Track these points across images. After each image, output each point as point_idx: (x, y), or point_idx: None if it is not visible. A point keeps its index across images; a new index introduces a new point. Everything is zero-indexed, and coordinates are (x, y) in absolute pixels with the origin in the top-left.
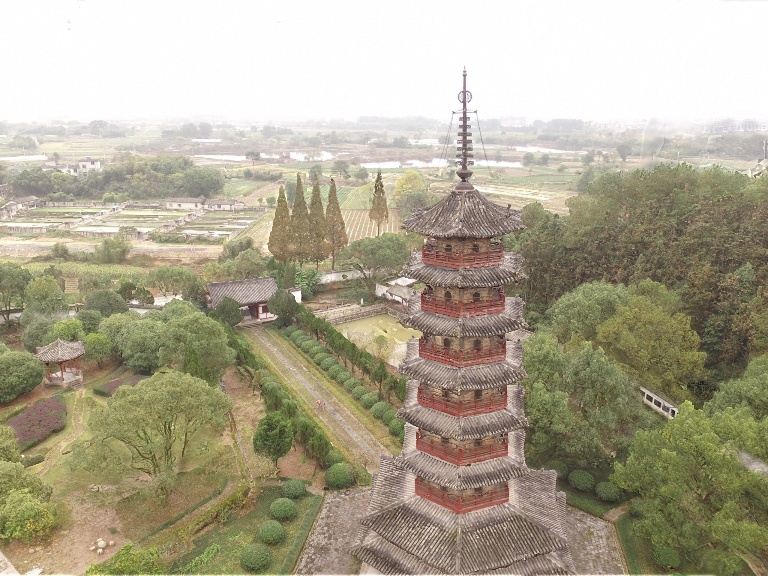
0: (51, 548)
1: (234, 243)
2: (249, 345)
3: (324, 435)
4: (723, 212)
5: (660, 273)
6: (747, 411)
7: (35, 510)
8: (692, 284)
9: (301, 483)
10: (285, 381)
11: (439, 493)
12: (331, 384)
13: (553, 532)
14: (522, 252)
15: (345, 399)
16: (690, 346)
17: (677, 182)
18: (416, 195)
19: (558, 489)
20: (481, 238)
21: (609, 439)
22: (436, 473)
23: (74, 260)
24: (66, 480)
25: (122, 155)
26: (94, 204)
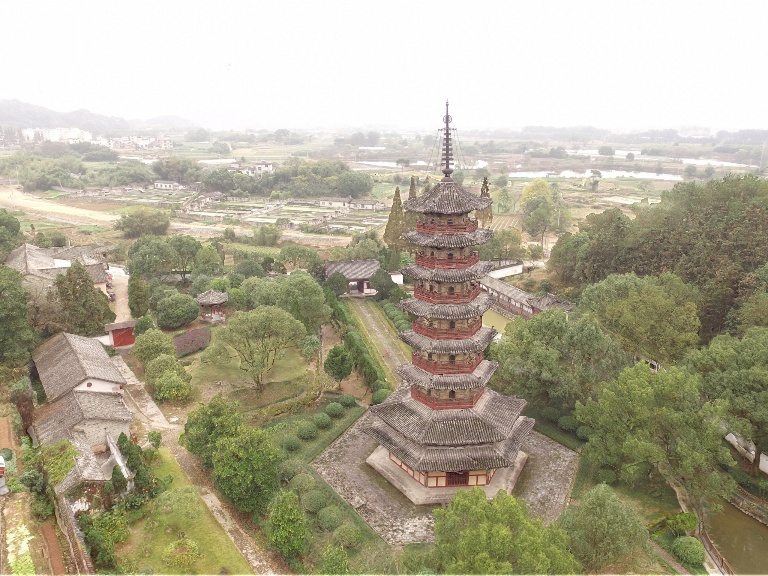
0: (186, 409)
1: (360, 234)
2: (350, 310)
3: (382, 373)
4: (767, 219)
5: (696, 271)
6: (685, 369)
7: (178, 383)
8: (719, 281)
9: (352, 396)
10: (368, 337)
11: (424, 396)
12: (402, 342)
13: (497, 430)
14: (589, 250)
15: (409, 353)
16: (691, 329)
17: (736, 191)
18: (535, 201)
19: (548, 428)
20: (454, 215)
21: (589, 390)
22: (420, 379)
23: (239, 242)
24: (202, 376)
25: (291, 160)
26: (263, 200)
